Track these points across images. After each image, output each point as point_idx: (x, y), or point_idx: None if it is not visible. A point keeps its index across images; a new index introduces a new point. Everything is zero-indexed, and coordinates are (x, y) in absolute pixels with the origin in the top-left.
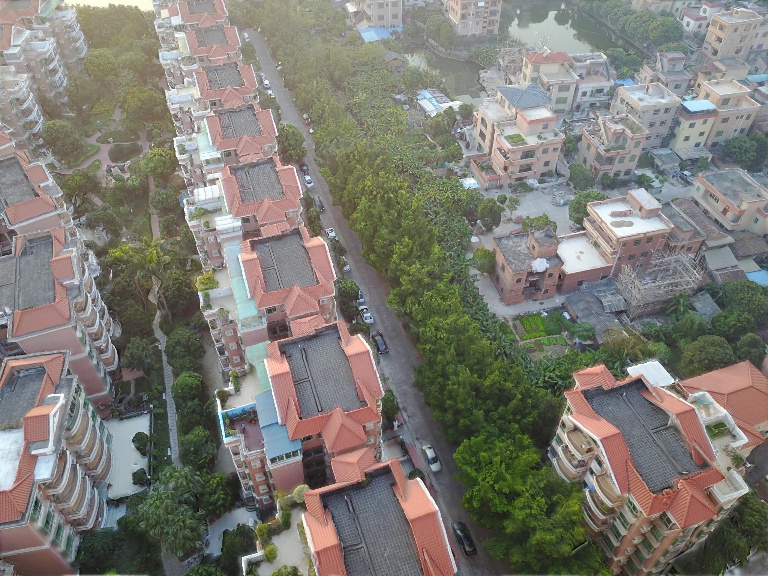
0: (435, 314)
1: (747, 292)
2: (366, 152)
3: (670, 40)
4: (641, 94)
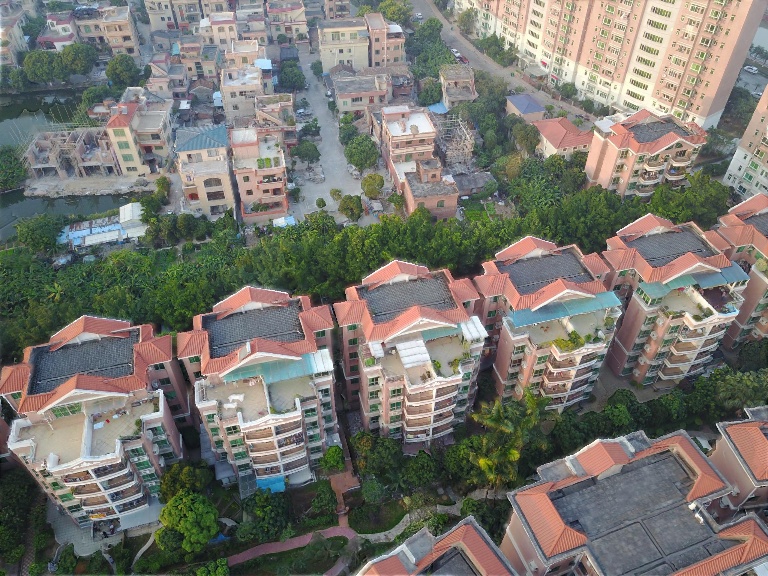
0: (513, 238)
1: (474, 107)
2: (290, 248)
3: (94, 62)
4: (233, 82)
